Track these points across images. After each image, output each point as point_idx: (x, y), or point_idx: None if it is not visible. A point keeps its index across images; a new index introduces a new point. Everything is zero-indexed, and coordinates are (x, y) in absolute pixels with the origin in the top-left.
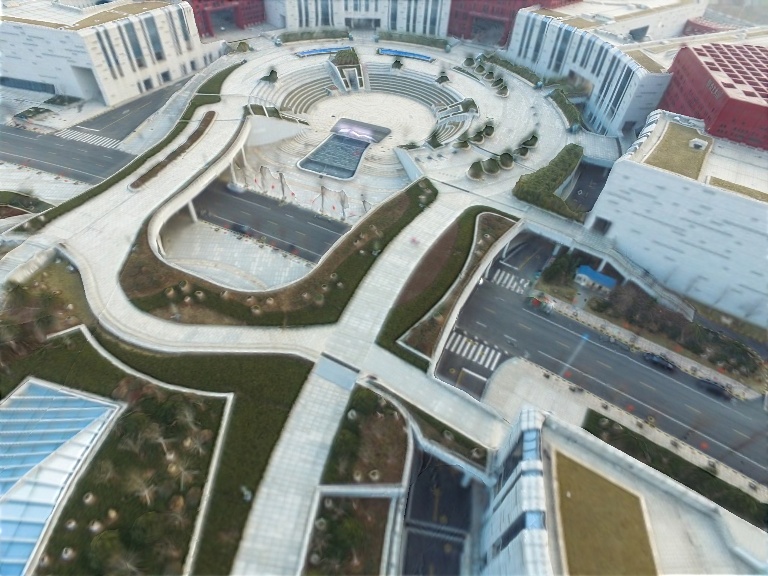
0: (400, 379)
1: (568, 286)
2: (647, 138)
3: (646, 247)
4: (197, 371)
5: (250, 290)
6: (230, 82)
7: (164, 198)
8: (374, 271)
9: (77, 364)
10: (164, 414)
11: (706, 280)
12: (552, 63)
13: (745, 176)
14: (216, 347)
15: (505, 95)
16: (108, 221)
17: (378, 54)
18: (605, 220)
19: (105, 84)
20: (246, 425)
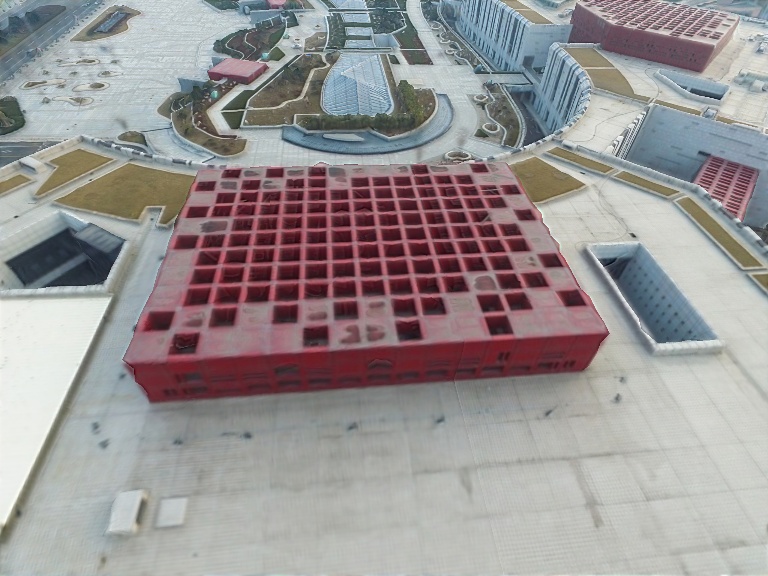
0: None
1: None
2: None
3: None
4: None
5: None
6: None
7: None
8: None
9: None
10: None
11: None
12: None
13: None
14: None
15: None
16: None
17: None
18: None
19: None
20: None
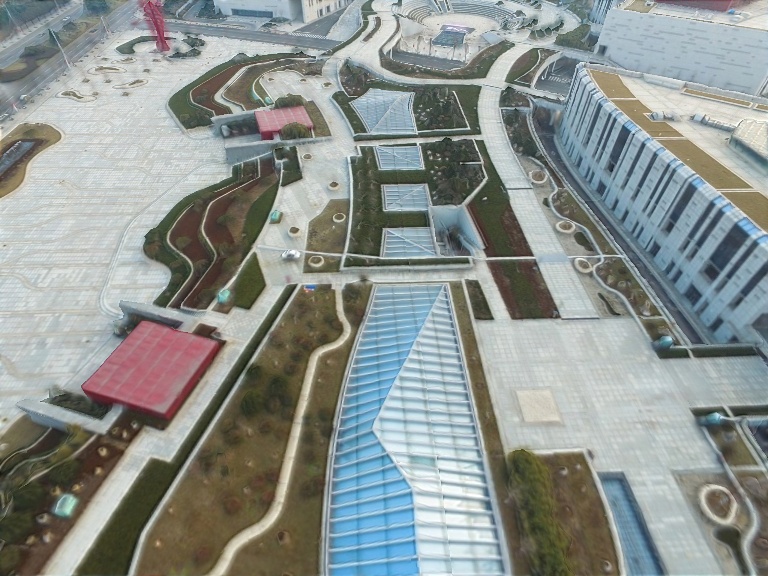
0: (520, 89)
1: None
2: (623, 3)
3: (625, 57)
4: None
5: None
6: (375, 7)
7: (382, 44)
8: (495, 65)
9: (387, 85)
10: None
11: (655, 69)
12: None
13: (671, 14)
14: (438, 83)
15: (540, 9)
16: (362, 52)
17: None
18: (604, 46)
19: (306, 9)
20: (464, 97)
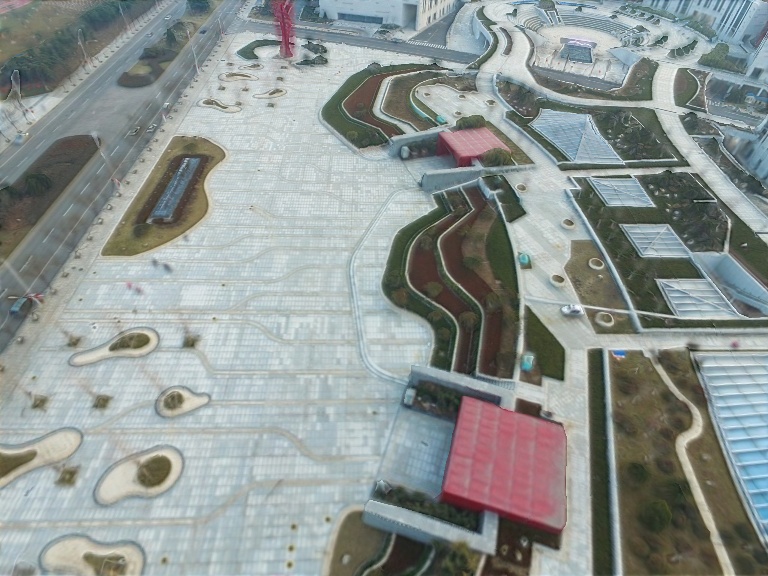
0: None
1: (742, 104)
2: None
3: None
4: (607, 110)
5: (603, 90)
6: (489, 16)
7: (525, 59)
8: (655, 85)
9: None
10: (619, 111)
11: None
12: (680, 8)
13: None
14: None
15: (658, 25)
16: (508, 66)
17: (559, 4)
18: (760, 69)
19: (419, 16)
20: None
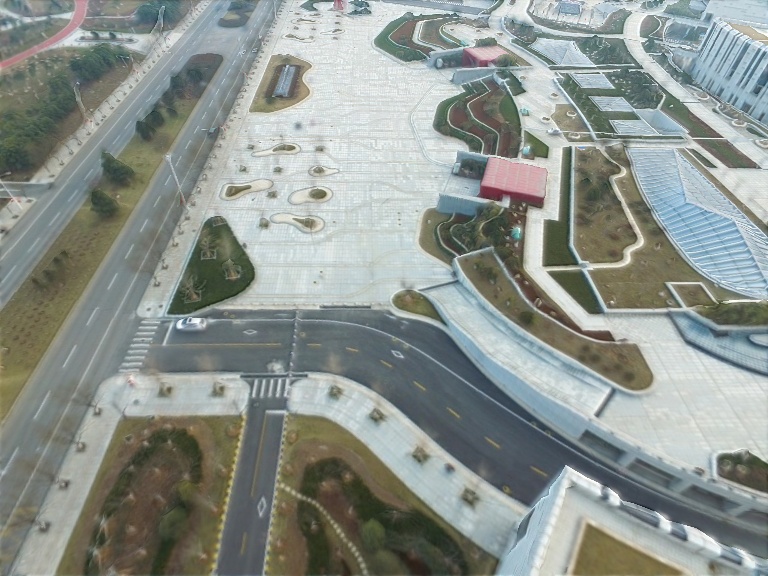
0: None
1: (696, 41)
2: None
3: None
4: None
5: None
6: None
7: None
8: (626, 25)
9: None
10: None
11: None
12: None
13: None
14: (588, 36)
15: None
16: None
17: None
18: (711, 14)
19: None
20: (615, 45)
